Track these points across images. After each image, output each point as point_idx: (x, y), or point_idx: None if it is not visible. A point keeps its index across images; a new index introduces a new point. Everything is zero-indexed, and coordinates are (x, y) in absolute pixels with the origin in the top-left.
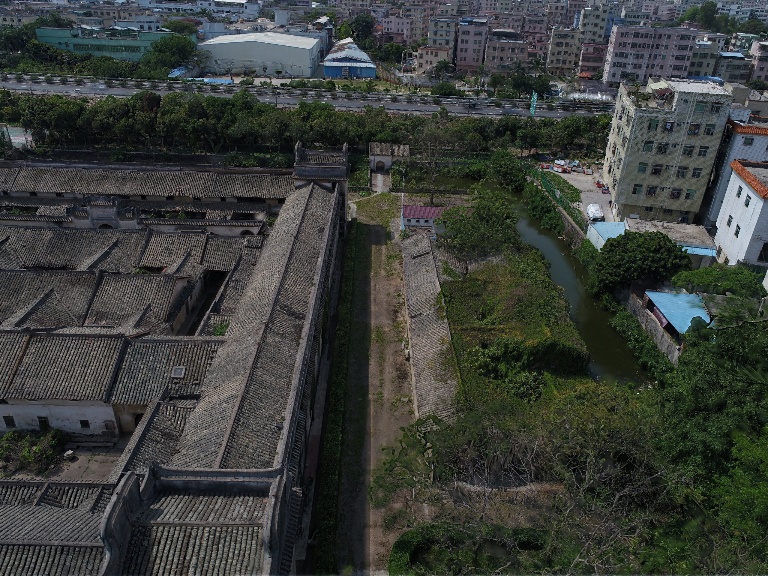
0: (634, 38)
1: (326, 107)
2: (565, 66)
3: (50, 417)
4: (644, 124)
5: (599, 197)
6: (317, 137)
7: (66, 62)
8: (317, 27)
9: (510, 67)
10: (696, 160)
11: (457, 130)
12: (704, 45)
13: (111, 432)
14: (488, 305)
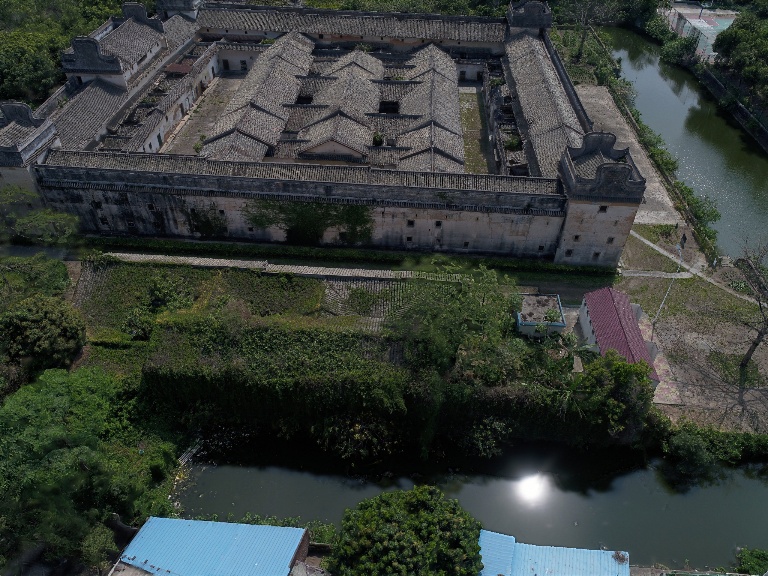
0: None
1: None
2: None
3: None
4: None
5: None
6: None
7: None
8: None
9: None
10: None
11: None
12: None
13: None
14: None
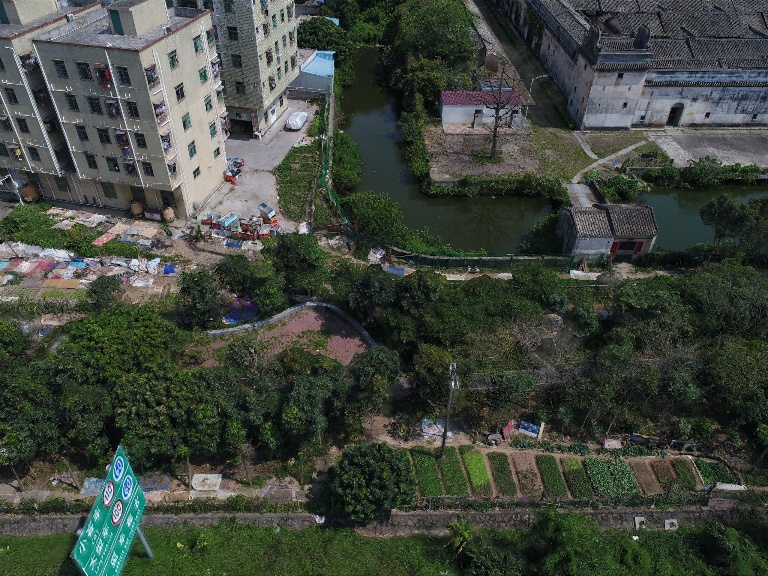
0: None
1: None
2: None
3: None
4: None
5: (258, 157)
6: None
7: None
8: None
9: None
10: None
11: (479, 277)
12: None
13: None
14: None
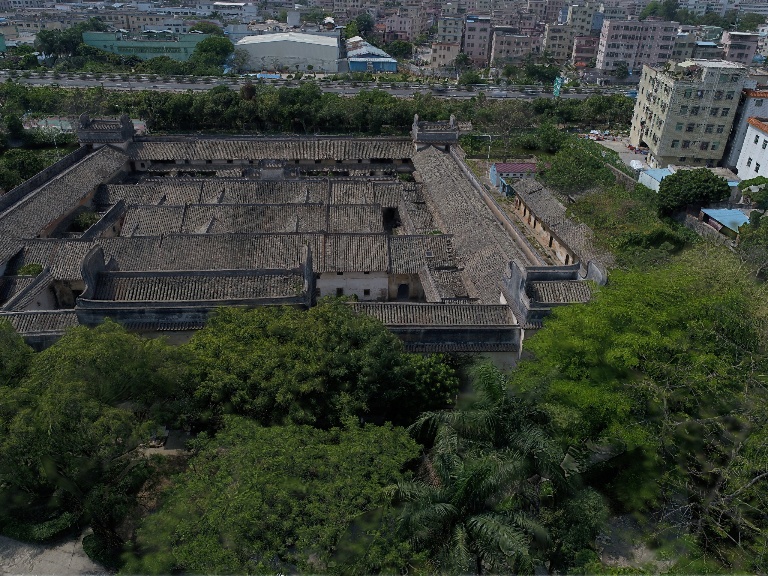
0: (624, 31)
1: (384, 94)
2: (559, 57)
3: (345, 288)
4: (681, 93)
5: (634, 156)
6: (394, 117)
7: (123, 63)
8: (328, 27)
9: (521, 58)
10: (720, 119)
11: (504, 109)
12: (682, 36)
13: (383, 298)
14: (601, 218)
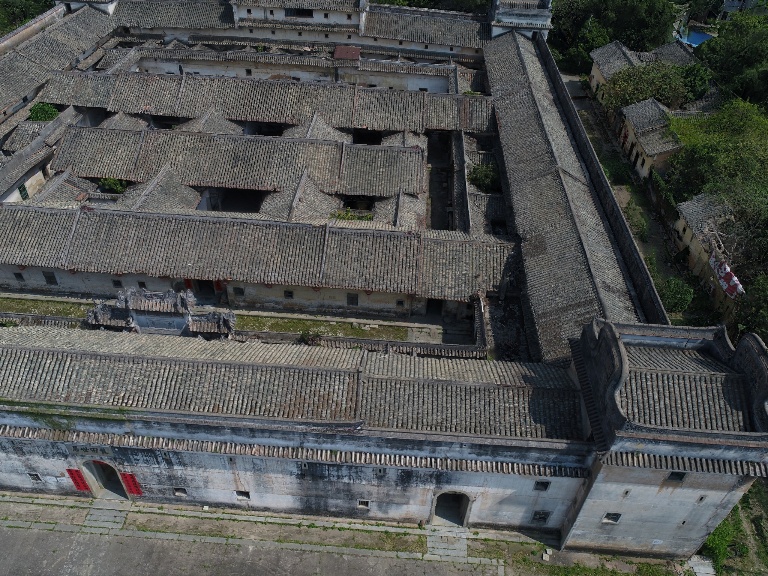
0: None
1: None
2: None
3: None
4: None
5: None
6: None
7: None
8: None
9: None
10: None
11: None
12: None
13: None
14: None
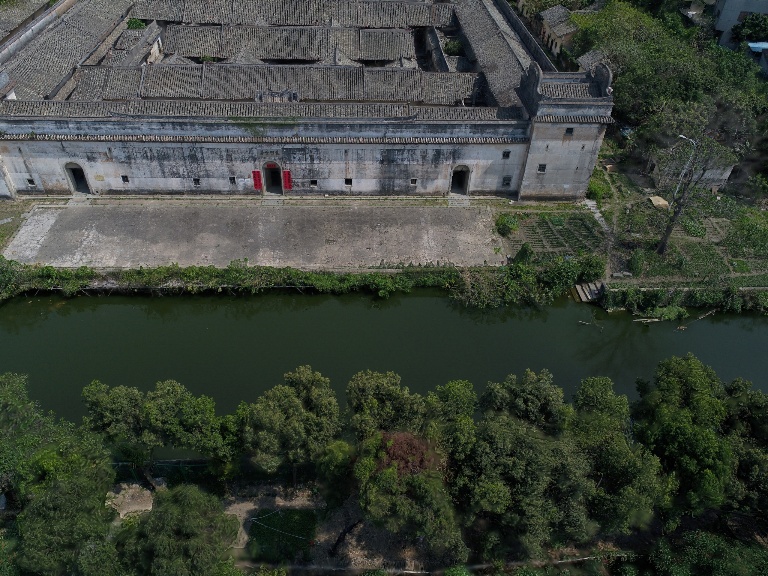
0: None
1: None
2: None
3: None
4: None
5: None
6: None
7: None
8: None
9: None
10: None
11: None
12: None
13: None
14: None
